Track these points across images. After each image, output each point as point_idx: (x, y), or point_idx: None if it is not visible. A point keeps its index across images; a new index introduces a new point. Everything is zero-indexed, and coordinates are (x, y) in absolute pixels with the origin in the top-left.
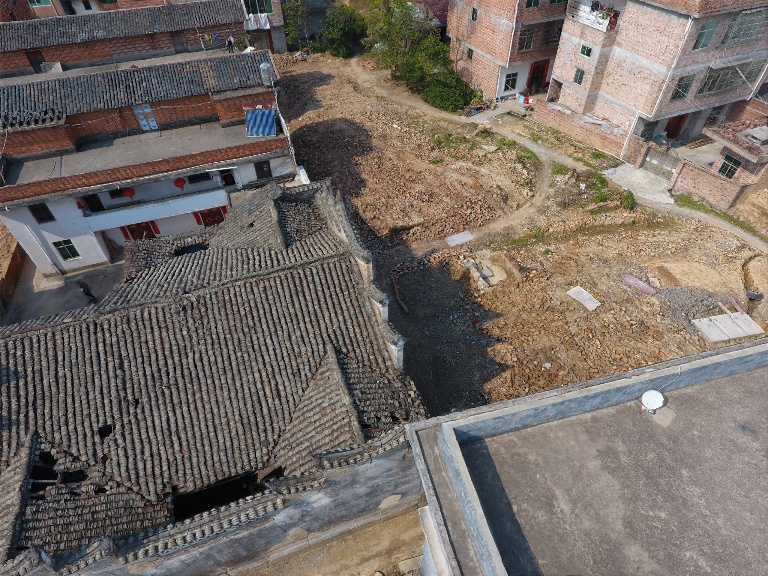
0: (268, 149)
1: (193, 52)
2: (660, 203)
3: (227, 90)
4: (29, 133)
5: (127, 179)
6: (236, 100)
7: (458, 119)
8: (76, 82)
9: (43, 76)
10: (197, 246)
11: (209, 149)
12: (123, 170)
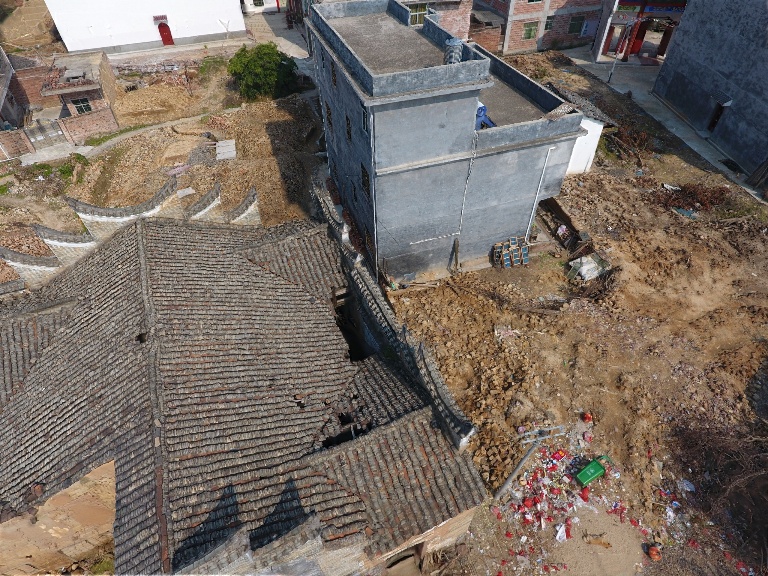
0: None
1: None
2: (89, 152)
3: None
4: None
5: None
6: None
7: None
8: None
9: None
10: None
11: None
12: None
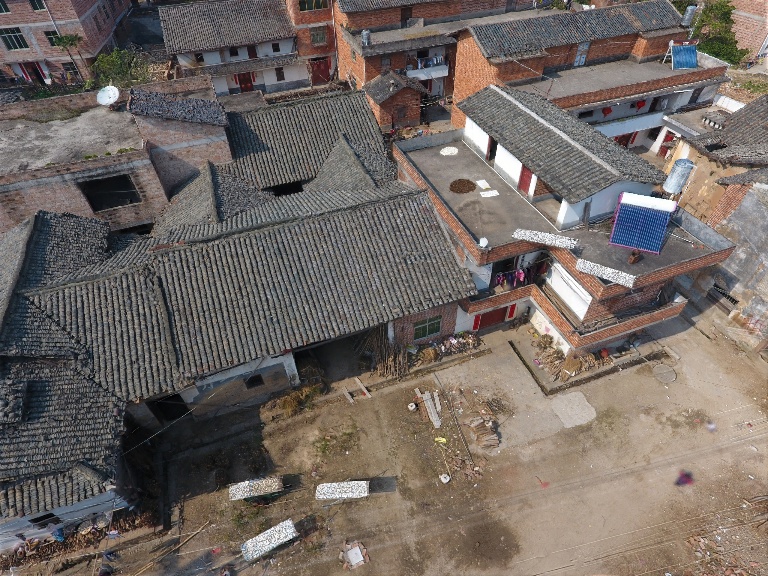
0: (710, 76)
1: (519, 11)
2: None
3: (651, 30)
4: (523, 62)
5: (616, 98)
6: (661, 38)
7: (737, 72)
8: (537, 22)
9: (411, 30)
10: (708, 147)
11: (653, 78)
12: (619, 89)
